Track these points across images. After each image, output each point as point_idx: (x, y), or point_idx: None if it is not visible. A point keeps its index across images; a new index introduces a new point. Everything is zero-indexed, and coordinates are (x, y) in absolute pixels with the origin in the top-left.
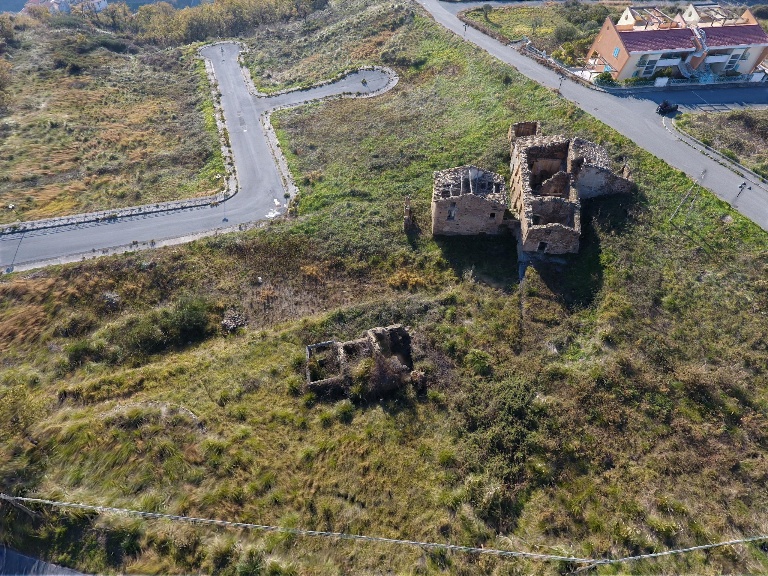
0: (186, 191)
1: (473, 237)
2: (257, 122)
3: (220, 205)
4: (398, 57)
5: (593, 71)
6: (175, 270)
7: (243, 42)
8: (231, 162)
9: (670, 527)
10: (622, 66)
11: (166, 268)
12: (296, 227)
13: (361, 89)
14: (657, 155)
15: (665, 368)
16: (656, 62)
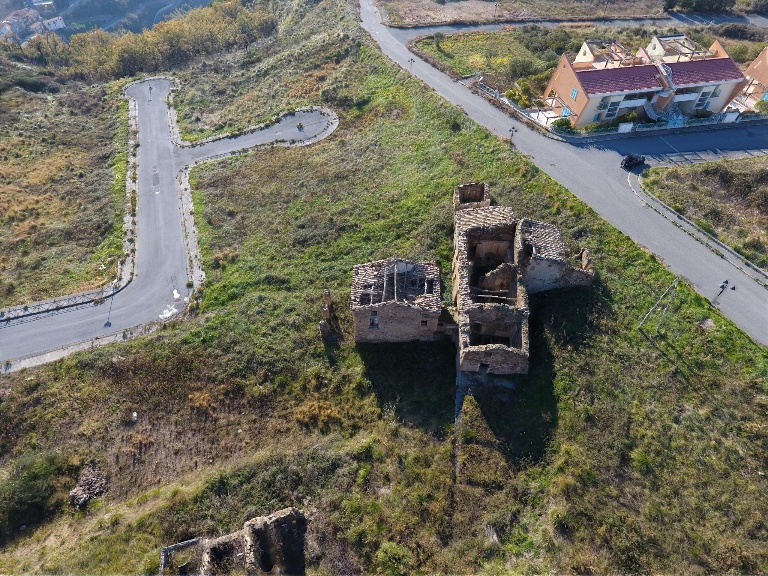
0: (71, 280)
1: (403, 346)
2: (173, 180)
3: (106, 302)
4: (339, 96)
5: (551, 112)
6: (27, 407)
7: (176, 77)
8: (131, 238)
9: None
10: (581, 110)
11: (14, 406)
12: (191, 334)
13: (296, 135)
14: (622, 229)
15: (637, 575)
16: (619, 104)
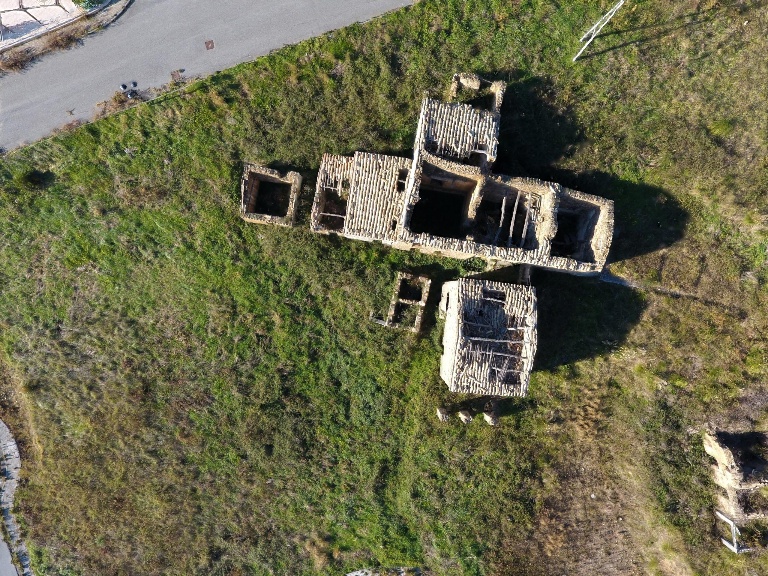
0: None
1: None
2: None
3: None
4: None
5: None
6: None
7: None
8: None
9: None
10: None
11: None
12: (467, 571)
13: None
14: (394, 2)
15: None
16: None
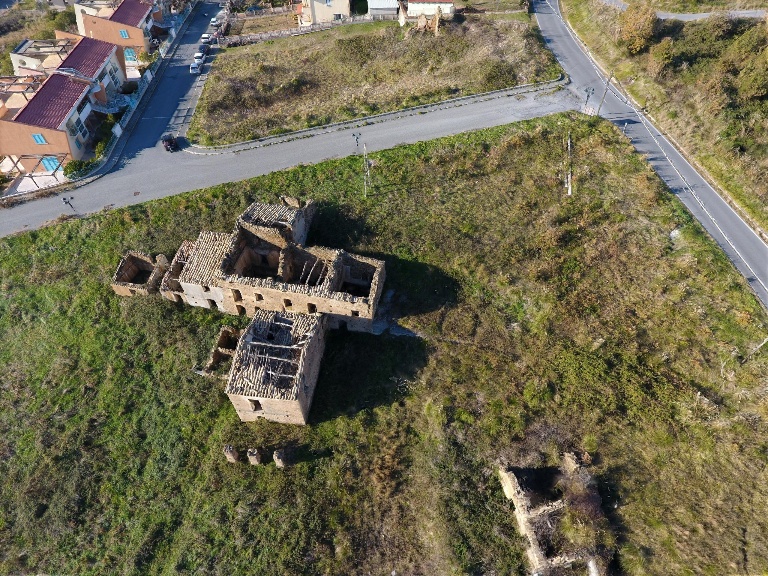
0: None
1: (326, 374)
2: None
3: None
4: None
5: None
6: None
7: None
8: None
9: (686, 289)
10: (67, 146)
11: None
12: None
13: None
14: (258, 174)
15: (537, 253)
16: (80, 120)
